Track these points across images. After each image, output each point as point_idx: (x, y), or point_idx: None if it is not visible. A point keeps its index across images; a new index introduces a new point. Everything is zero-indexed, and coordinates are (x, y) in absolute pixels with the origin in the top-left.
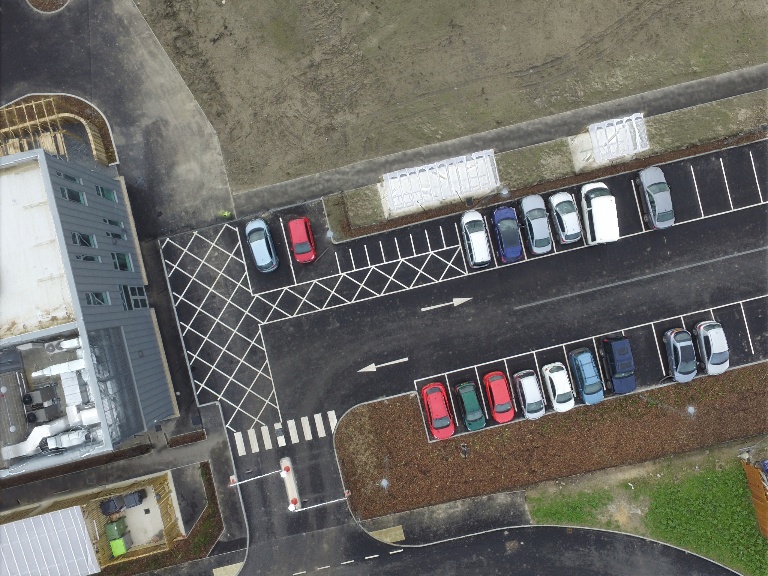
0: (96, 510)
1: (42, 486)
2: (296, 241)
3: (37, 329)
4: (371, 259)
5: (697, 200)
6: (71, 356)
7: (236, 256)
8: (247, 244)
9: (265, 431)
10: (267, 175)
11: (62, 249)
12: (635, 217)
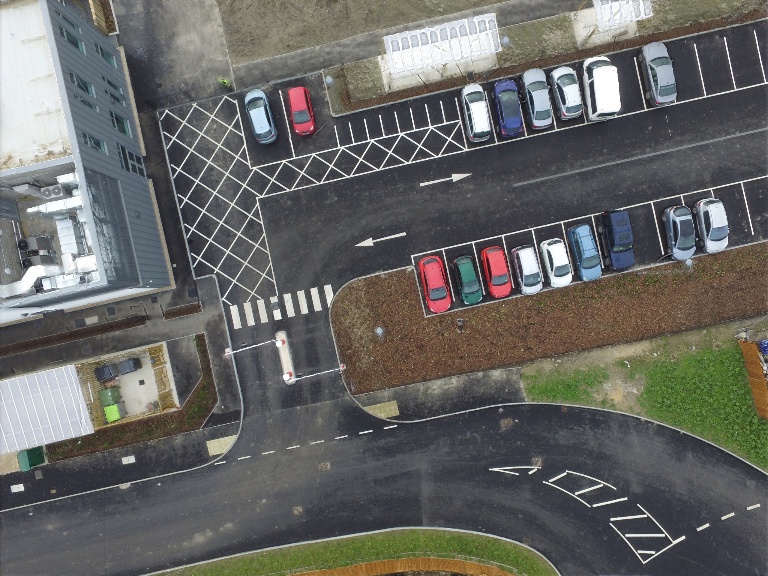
0: (90, 375)
1: (37, 355)
2: (295, 109)
3: (33, 163)
4: (370, 133)
5: (700, 79)
6: None
7: (235, 129)
8: (246, 117)
9: (261, 305)
10: (267, 47)
11: (59, 82)
12: (637, 95)
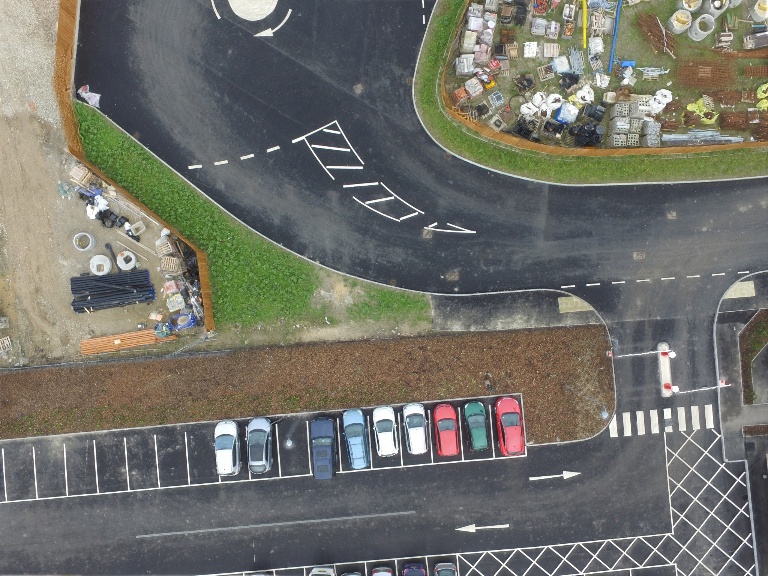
0: None
1: None
2: None
3: None
4: None
5: None
6: None
7: None
8: None
9: (682, 426)
10: None
11: None
12: None
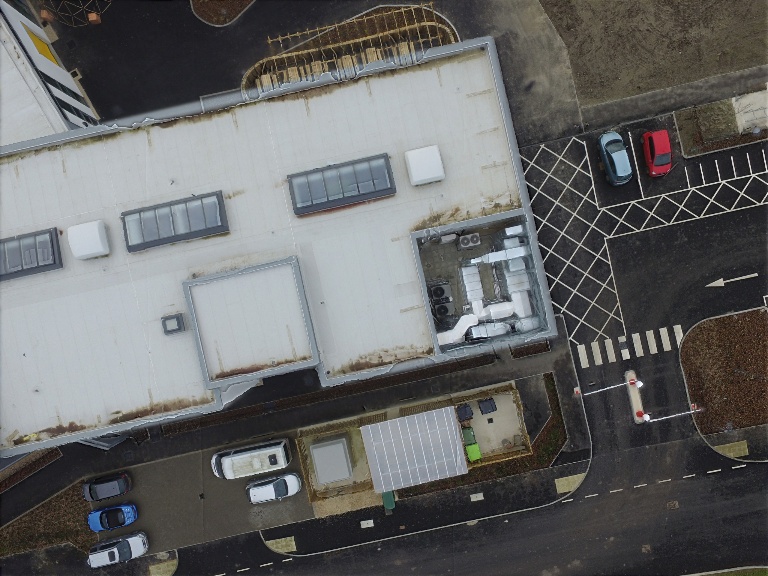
0: None
1: (387, 393)
2: (660, 152)
3: (481, 215)
4: (722, 174)
5: None
6: (465, 254)
7: (583, 170)
8: (595, 158)
9: (609, 344)
10: (617, 89)
11: (510, 136)
12: None
